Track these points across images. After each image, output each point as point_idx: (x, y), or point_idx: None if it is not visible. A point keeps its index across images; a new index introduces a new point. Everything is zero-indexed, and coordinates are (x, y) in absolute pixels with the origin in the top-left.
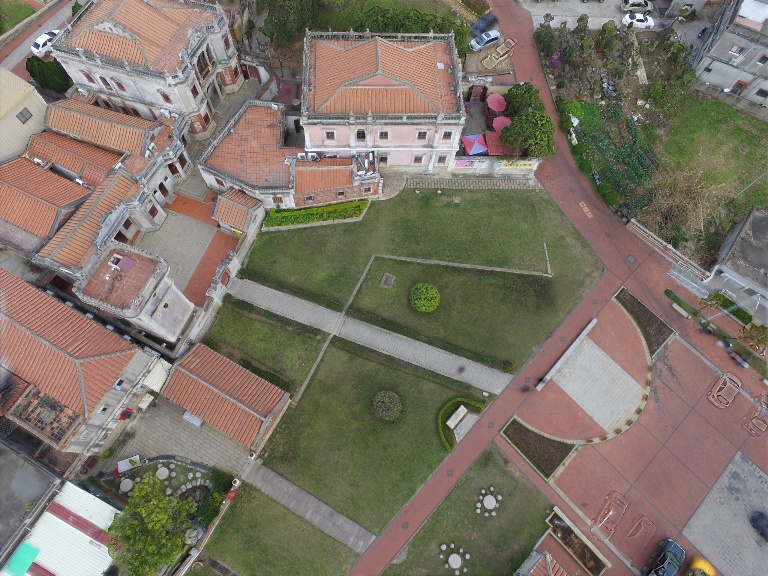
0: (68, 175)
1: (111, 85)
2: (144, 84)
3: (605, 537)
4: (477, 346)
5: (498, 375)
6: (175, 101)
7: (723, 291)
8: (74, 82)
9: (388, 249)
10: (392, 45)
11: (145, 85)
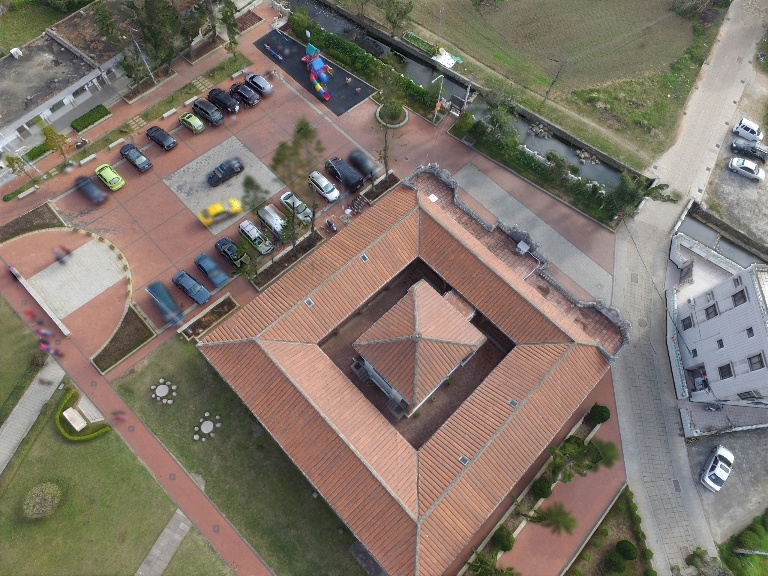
0: None
1: None
2: None
3: (206, 294)
4: (5, 392)
5: (44, 372)
6: None
7: (16, 154)
8: None
9: None
10: None
11: None
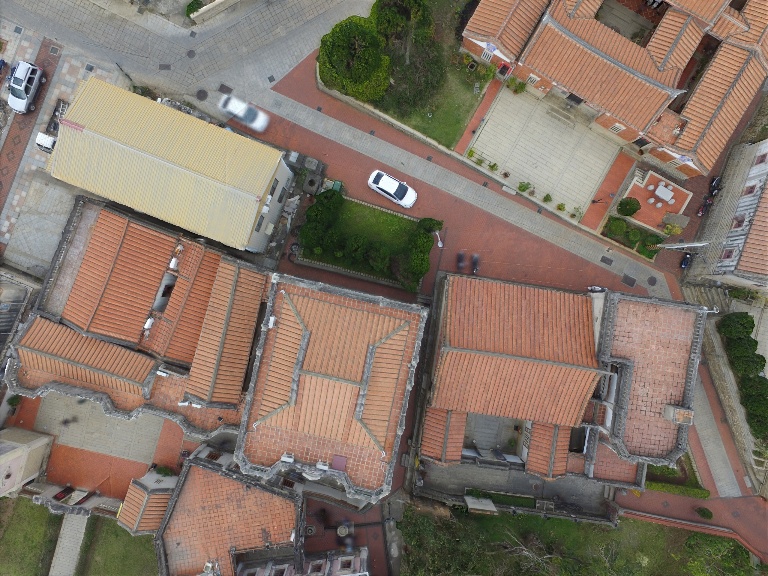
0: None
1: None
2: None
3: None
4: None
5: None
6: None
7: None
8: None
9: None
10: None
11: None
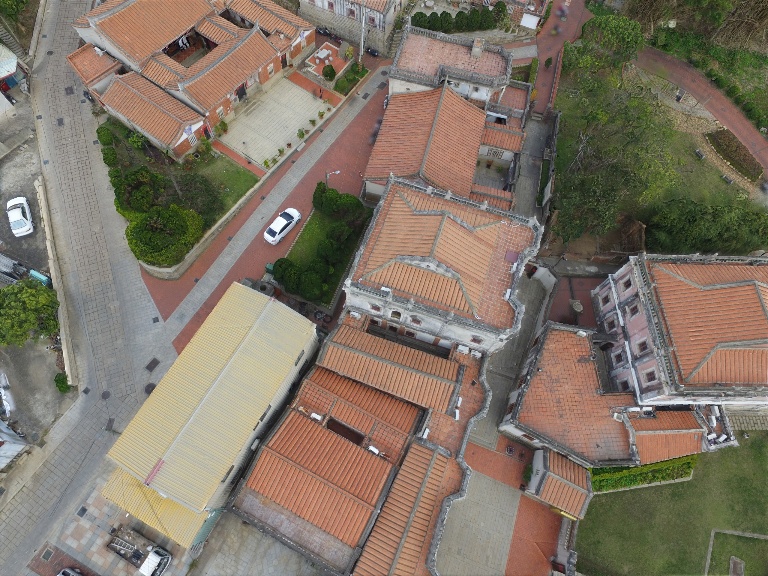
0: (339, 422)
1: (403, 317)
2: (458, 328)
3: None
4: None
5: None
6: (487, 344)
7: None
8: (347, 304)
9: (729, 521)
10: (766, 287)
11: (458, 329)
